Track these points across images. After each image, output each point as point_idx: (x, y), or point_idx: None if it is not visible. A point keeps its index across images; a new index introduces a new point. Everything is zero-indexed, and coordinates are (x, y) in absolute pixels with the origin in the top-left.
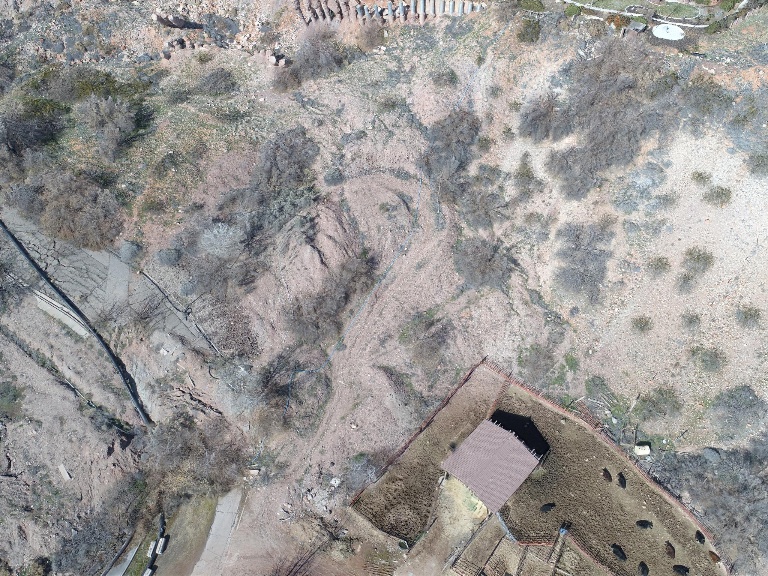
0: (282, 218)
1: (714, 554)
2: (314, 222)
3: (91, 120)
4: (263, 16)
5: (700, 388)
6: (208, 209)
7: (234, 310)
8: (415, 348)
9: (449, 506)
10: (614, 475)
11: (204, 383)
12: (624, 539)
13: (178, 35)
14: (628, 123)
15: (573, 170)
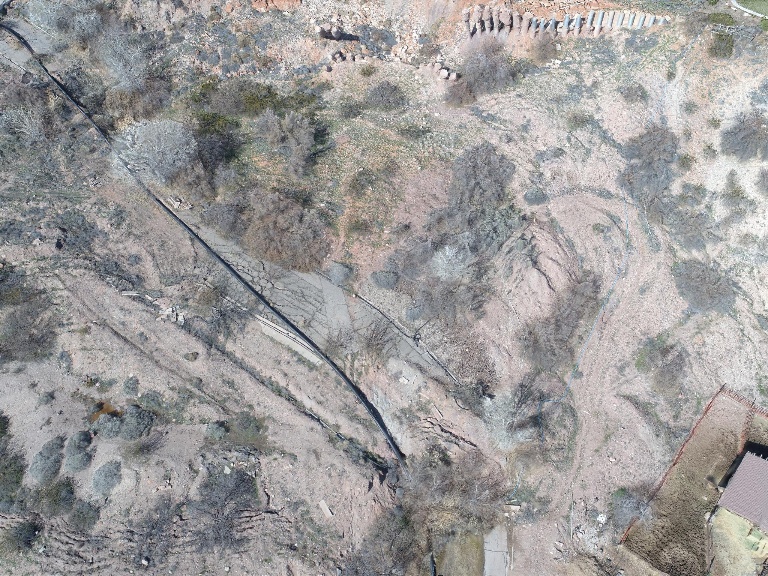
0: (500, 240)
1: None
2: (532, 244)
3: (274, 136)
4: (419, 27)
5: None
6: (415, 229)
7: (467, 336)
8: (655, 376)
9: (724, 544)
10: None
11: (453, 414)
12: None
13: (334, 47)
14: None
15: None
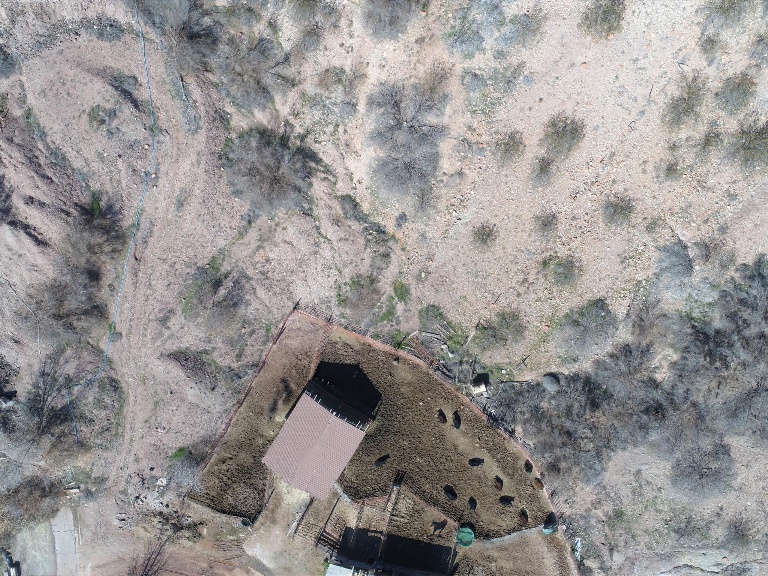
0: None
1: (539, 482)
2: None
3: None
4: None
5: (548, 306)
6: None
7: None
8: (206, 320)
9: None
10: (449, 416)
11: None
12: (456, 479)
13: None
14: None
15: None
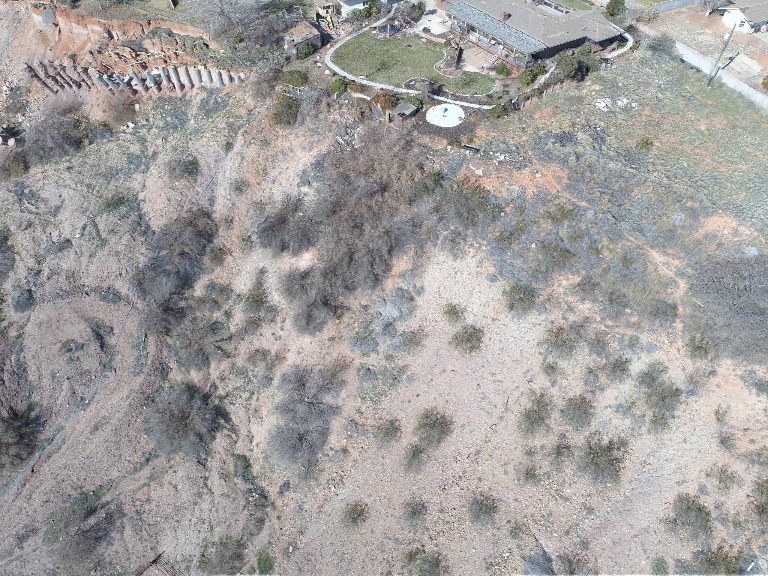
0: None
1: None
2: None
3: None
4: (14, 79)
5: None
6: None
7: None
8: (62, 548)
9: None
10: None
11: None
12: None
13: None
14: (366, 242)
15: (309, 295)
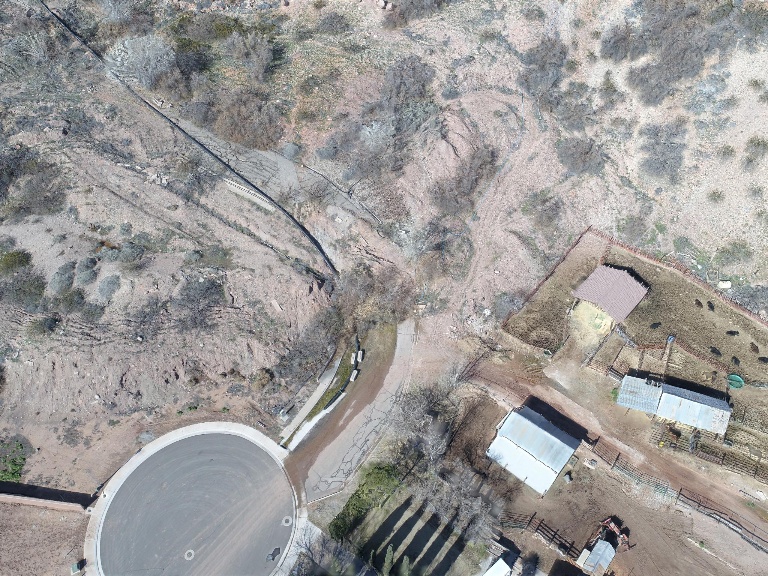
0: (418, 121)
1: None
2: (443, 124)
3: (239, 51)
4: None
5: (766, 241)
6: (352, 117)
7: (389, 190)
8: (536, 218)
9: (578, 327)
10: (704, 303)
11: (376, 241)
12: (718, 343)
13: None
14: (696, 41)
15: (650, 82)
